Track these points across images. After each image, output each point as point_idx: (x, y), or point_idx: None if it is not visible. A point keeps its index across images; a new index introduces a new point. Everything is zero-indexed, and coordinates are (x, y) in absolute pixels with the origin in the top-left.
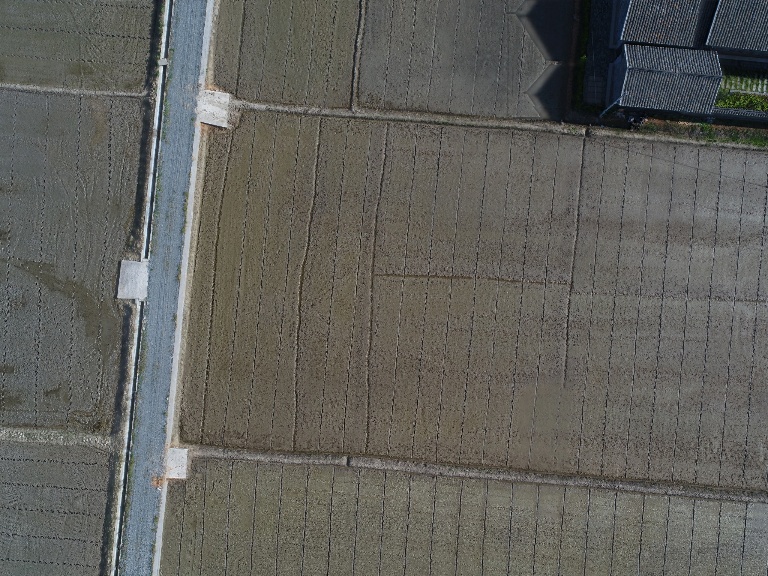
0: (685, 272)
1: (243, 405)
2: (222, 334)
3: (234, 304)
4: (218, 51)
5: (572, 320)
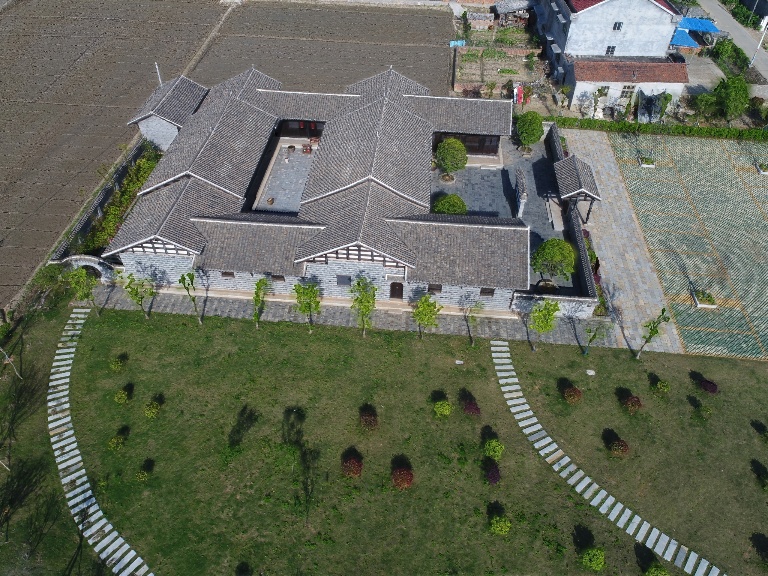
0: (0, 153)
1: (44, 4)
2: (93, 0)
3: (109, 3)
4: (269, 2)
5: (3, 102)
